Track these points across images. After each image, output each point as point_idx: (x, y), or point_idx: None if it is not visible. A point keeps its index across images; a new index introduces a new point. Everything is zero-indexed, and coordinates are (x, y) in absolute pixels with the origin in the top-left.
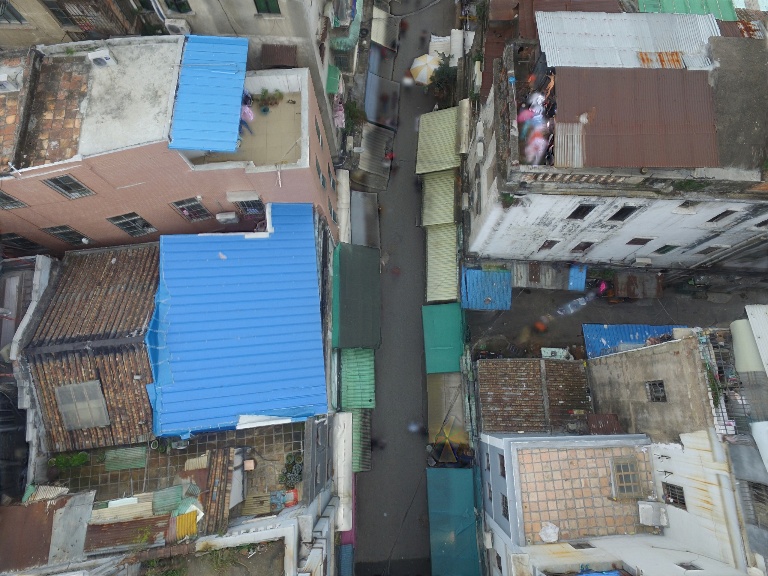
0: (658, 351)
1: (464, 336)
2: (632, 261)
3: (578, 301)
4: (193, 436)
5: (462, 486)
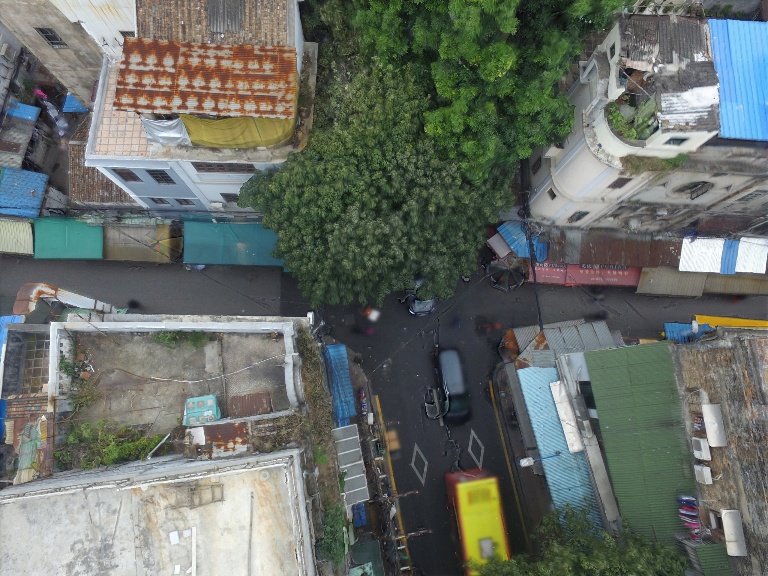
0: (8, 26)
1: (62, 217)
2: (5, 59)
3: (74, 124)
4: (2, 446)
5: (200, 233)
